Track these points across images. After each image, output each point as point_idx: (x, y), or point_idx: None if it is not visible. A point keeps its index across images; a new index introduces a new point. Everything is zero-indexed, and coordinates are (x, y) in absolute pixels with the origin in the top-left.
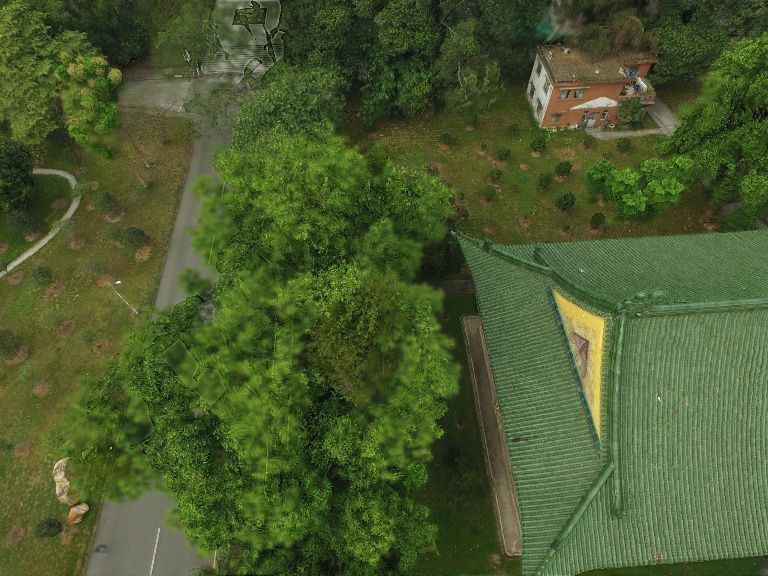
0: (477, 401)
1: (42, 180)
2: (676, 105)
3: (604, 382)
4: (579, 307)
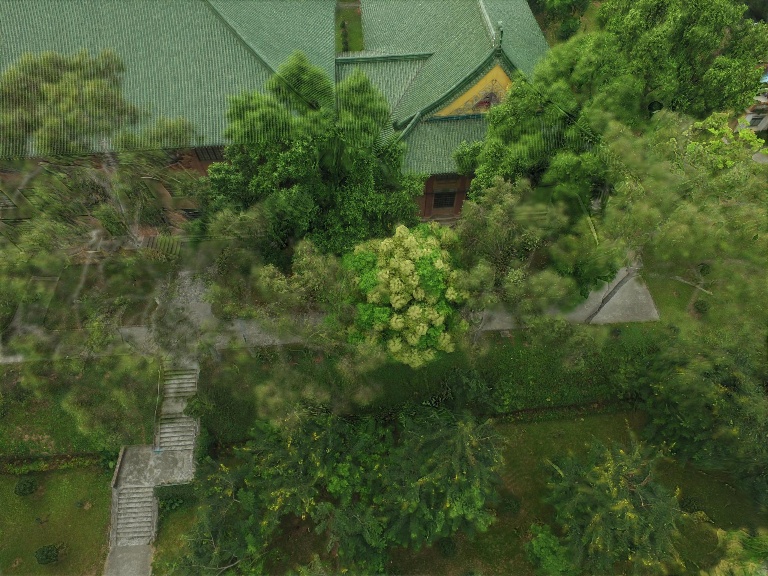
0: None
1: None
2: None
3: None
4: None
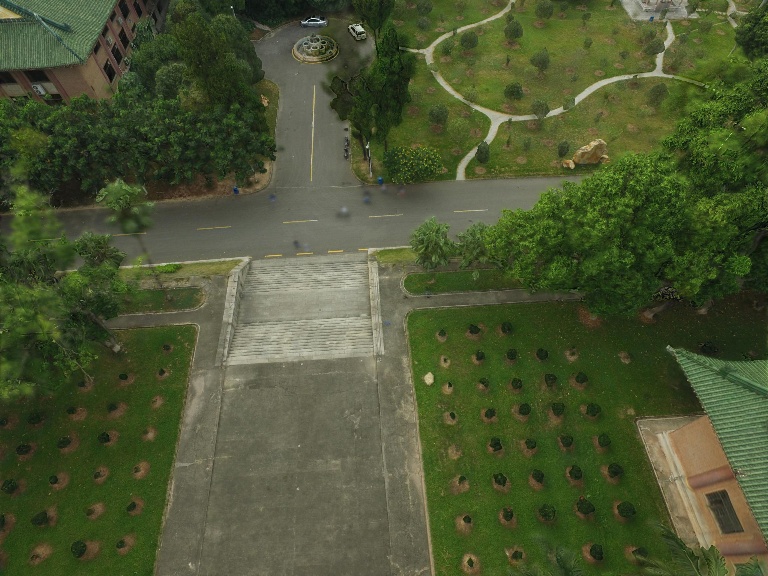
0: None
1: None
2: None
3: None
4: None
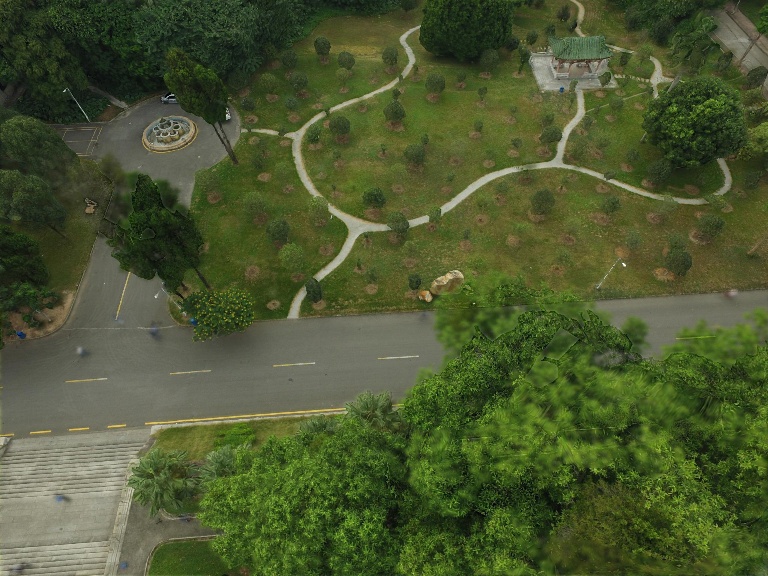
0: None
1: (712, 168)
2: None
3: None
4: None
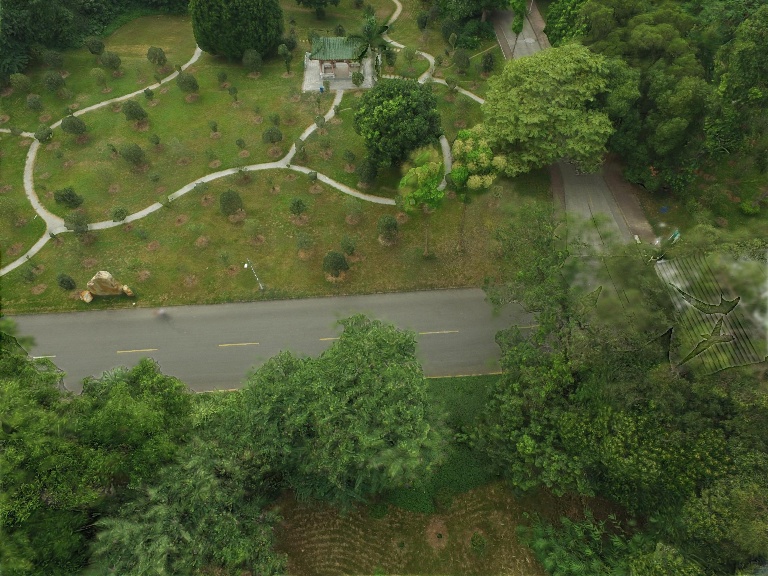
0: None
1: None
2: None
3: None
4: None
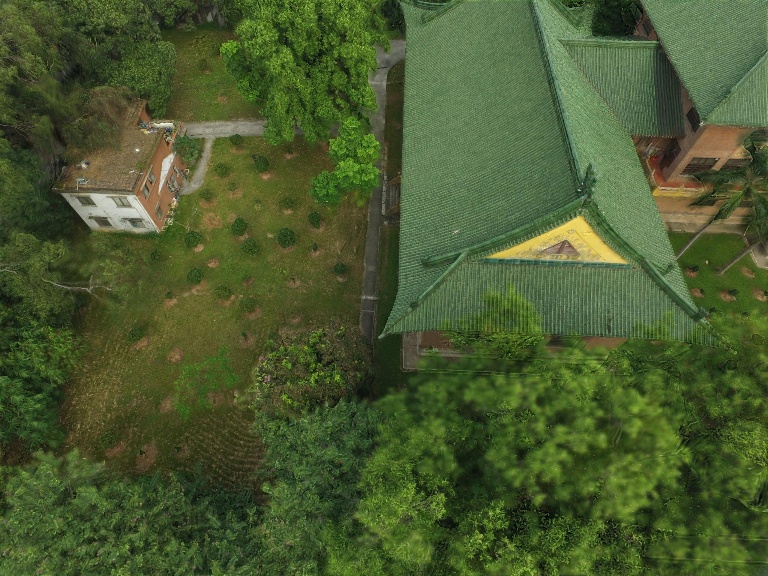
0: (496, 374)
1: None
2: (180, 117)
3: (606, 240)
4: (541, 235)
